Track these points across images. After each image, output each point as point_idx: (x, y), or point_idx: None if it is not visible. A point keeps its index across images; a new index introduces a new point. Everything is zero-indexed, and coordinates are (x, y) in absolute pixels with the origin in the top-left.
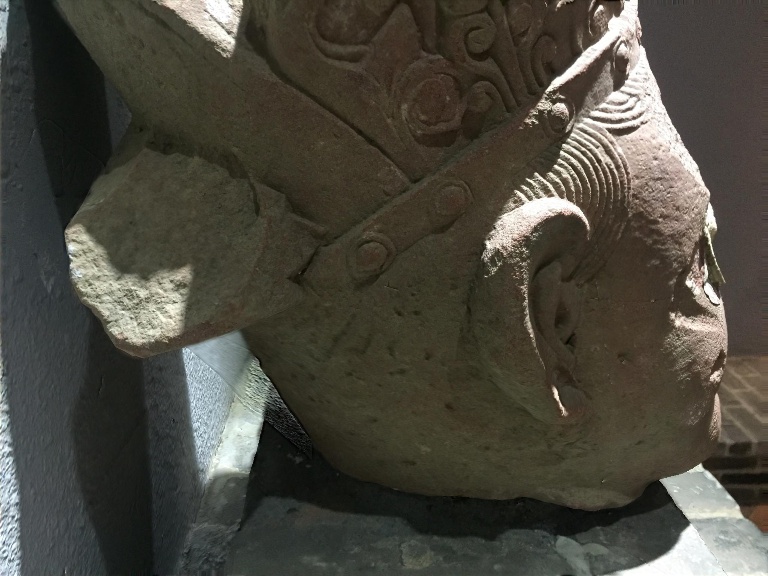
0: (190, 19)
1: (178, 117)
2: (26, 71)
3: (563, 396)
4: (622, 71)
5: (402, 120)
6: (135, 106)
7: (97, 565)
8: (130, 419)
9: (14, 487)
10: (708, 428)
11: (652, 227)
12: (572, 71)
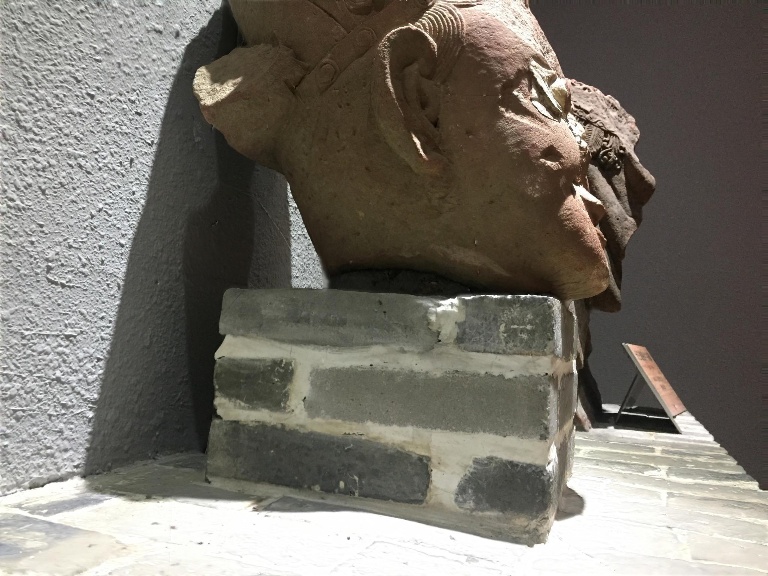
0: None
1: (258, 27)
2: (214, 44)
3: (429, 154)
4: None
5: (342, 1)
6: (246, 34)
7: (180, 316)
8: (232, 273)
9: (144, 197)
10: (557, 212)
11: (480, 51)
12: None
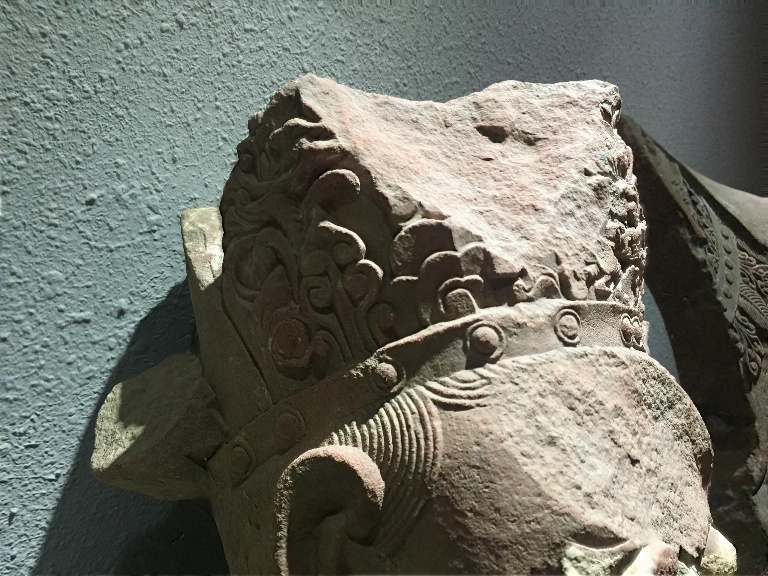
0: (196, 265)
1: None
2: None
3: None
4: (483, 353)
5: (269, 350)
6: None
7: None
8: None
9: (36, 554)
10: None
11: (458, 519)
12: (407, 338)
